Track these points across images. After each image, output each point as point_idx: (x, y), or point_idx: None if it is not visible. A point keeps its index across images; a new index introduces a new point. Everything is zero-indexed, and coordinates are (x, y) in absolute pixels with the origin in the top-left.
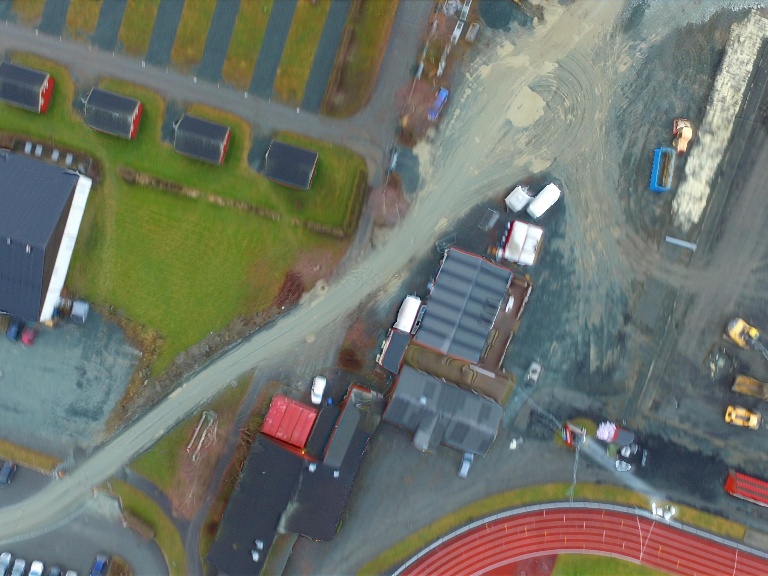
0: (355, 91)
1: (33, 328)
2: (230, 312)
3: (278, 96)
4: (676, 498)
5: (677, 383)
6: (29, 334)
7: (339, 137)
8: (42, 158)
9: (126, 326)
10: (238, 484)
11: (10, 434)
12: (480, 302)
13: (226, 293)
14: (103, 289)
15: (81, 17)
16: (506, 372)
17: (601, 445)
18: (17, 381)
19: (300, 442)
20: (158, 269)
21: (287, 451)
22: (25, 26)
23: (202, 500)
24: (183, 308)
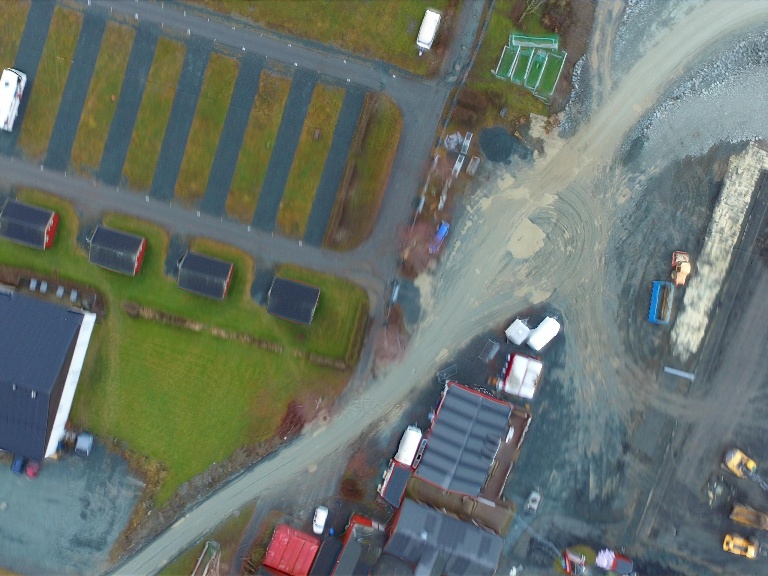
0: (357, 224)
1: (38, 461)
2: (233, 443)
3: (281, 229)
4: None
5: (675, 511)
6: (34, 468)
7: (341, 269)
8: (47, 294)
9: (130, 458)
10: None
11: (15, 565)
12: (480, 438)
13: (229, 424)
14: (107, 421)
15: (86, 153)
16: (506, 501)
17: (600, 572)
18: (22, 512)
19: (302, 574)
20: (161, 401)
21: None
22: (30, 162)
23: None
24: (186, 440)
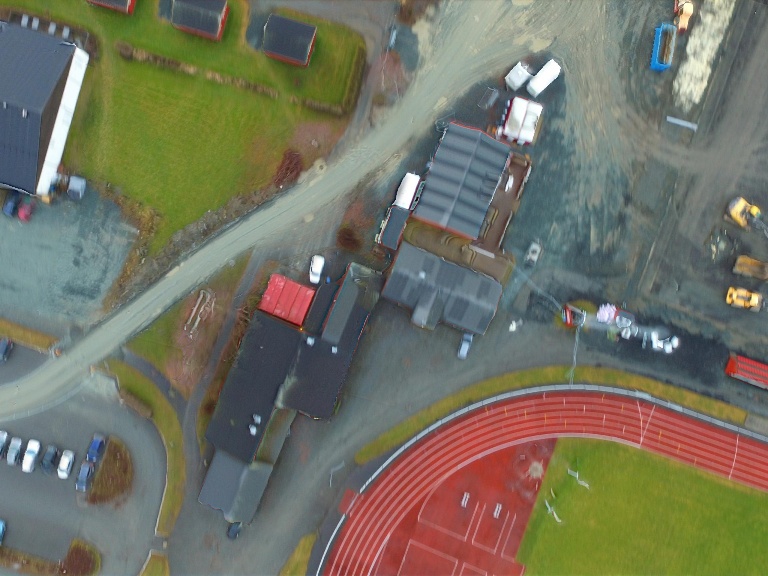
0: None
1: (30, 204)
2: (228, 191)
3: None
4: (677, 382)
5: (678, 265)
6: (26, 209)
7: (338, 14)
8: (39, 31)
9: (123, 204)
10: (236, 361)
11: (6, 312)
12: (479, 176)
13: (224, 171)
14: (100, 166)
15: None
16: (506, 253)
17: (601, 328)
18: (13, 258)
19: (298, 319)
20: (155, 146)
21: (285, 327)
22: None
23: (199, 377)
24: (181, 186)
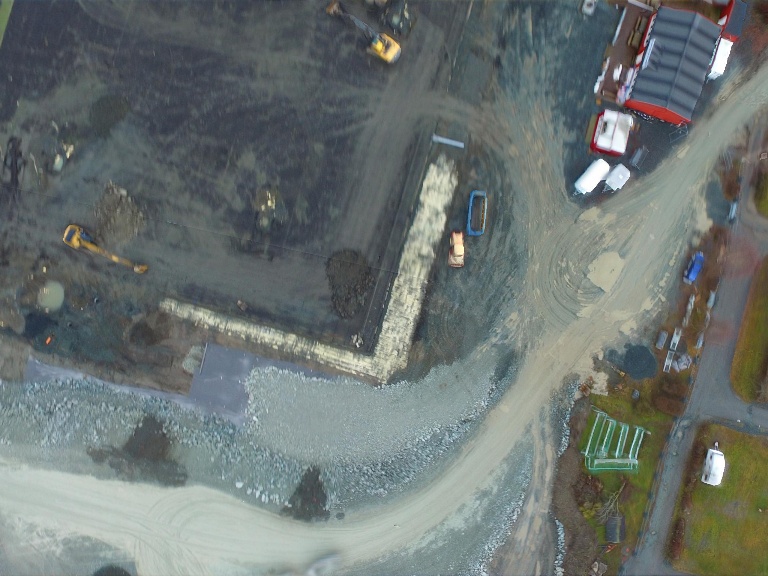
0: None
1: None
2: None
3: None
4: None
5: None
6: None
7: None
8: None
9: None
10: None
11: None
12: (665, 67)
13: None
14: None
15: None
16: (616, 5)
17: None
18: None
19: None
20: None
21: None
22: None
23: None
24: None
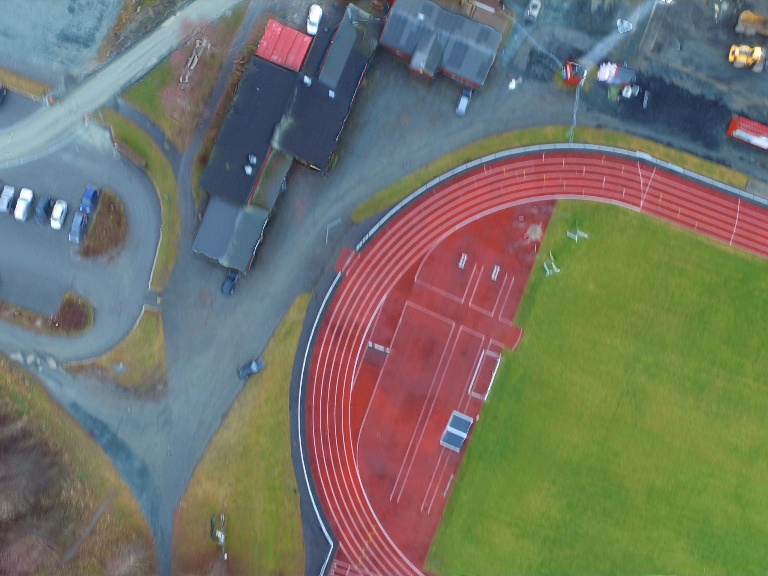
0: None
1: None
2: None
3: None
4: (678, 145)
5: (680, 24)
6: None
7: None
8: None
9: None
10: (232, 107)
11: None
12: None
13: None
14: None
15: None
16: (506, 9)
17: (602, 87)
18: (8, 4)
19: (295, 66)
20: None
21: None
22: None
23: (195, 122)
24: None
